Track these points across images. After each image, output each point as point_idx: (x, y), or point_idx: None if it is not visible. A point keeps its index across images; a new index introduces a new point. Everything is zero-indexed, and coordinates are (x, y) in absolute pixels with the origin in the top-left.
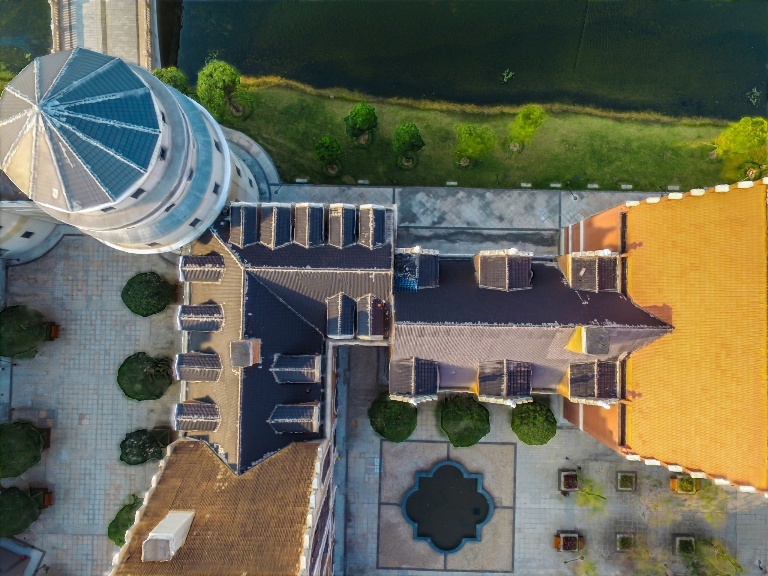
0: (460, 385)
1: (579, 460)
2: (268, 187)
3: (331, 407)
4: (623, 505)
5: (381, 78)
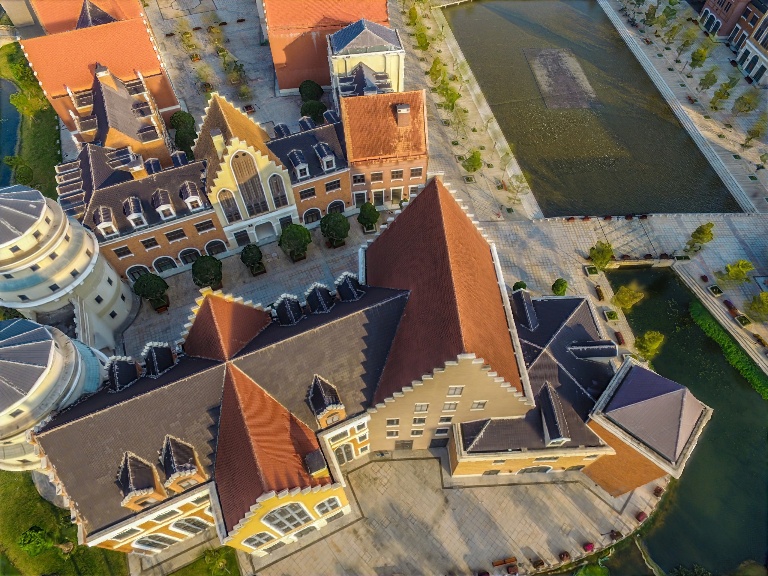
0: None
1: None
2: None
3: None
4: None
5: None
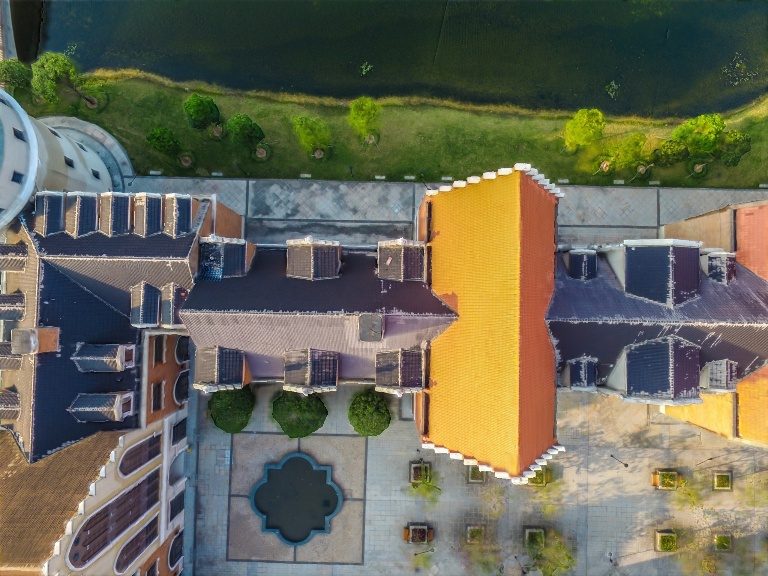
0: (281, 375)
1: (430, 452)
2: (122, 179)
3: (147, 397)
4: (474, 497)
5: (240, 71)
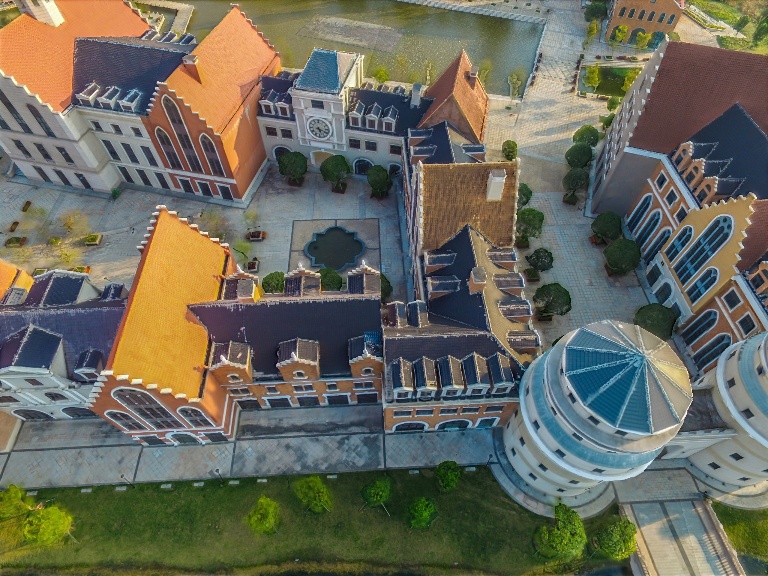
0: None
1: None
2: (499, 460)
3: (418, 274)
4: None
5: None
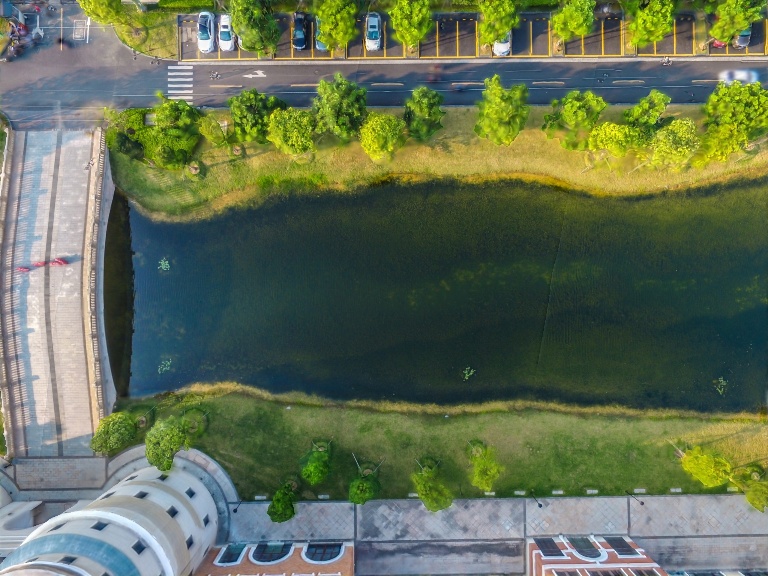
0: None
1: None
2: (227, 506)
3: None
4: None
5: (339, 380)
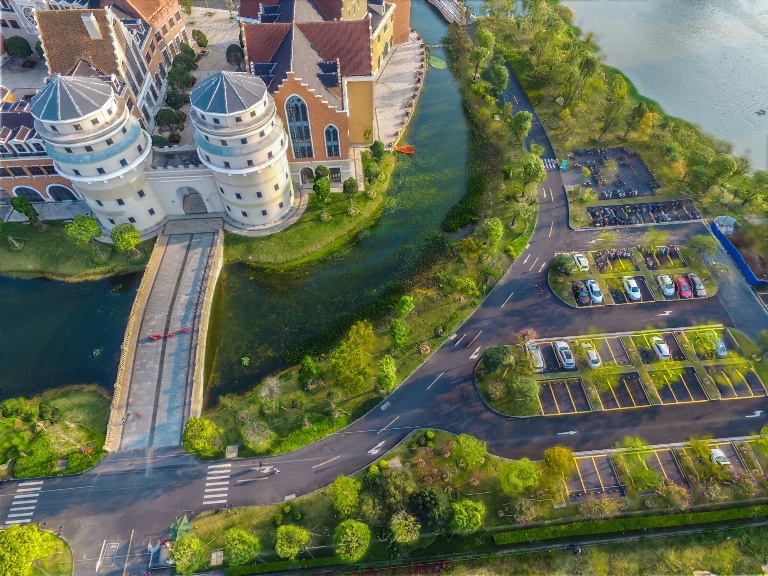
0: None
1: None
2: (92, 216)
3: None
4: None
5: None
